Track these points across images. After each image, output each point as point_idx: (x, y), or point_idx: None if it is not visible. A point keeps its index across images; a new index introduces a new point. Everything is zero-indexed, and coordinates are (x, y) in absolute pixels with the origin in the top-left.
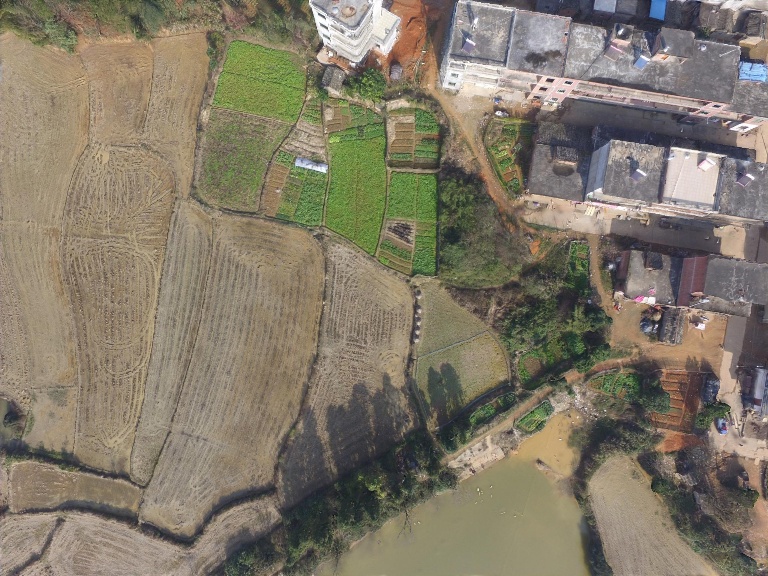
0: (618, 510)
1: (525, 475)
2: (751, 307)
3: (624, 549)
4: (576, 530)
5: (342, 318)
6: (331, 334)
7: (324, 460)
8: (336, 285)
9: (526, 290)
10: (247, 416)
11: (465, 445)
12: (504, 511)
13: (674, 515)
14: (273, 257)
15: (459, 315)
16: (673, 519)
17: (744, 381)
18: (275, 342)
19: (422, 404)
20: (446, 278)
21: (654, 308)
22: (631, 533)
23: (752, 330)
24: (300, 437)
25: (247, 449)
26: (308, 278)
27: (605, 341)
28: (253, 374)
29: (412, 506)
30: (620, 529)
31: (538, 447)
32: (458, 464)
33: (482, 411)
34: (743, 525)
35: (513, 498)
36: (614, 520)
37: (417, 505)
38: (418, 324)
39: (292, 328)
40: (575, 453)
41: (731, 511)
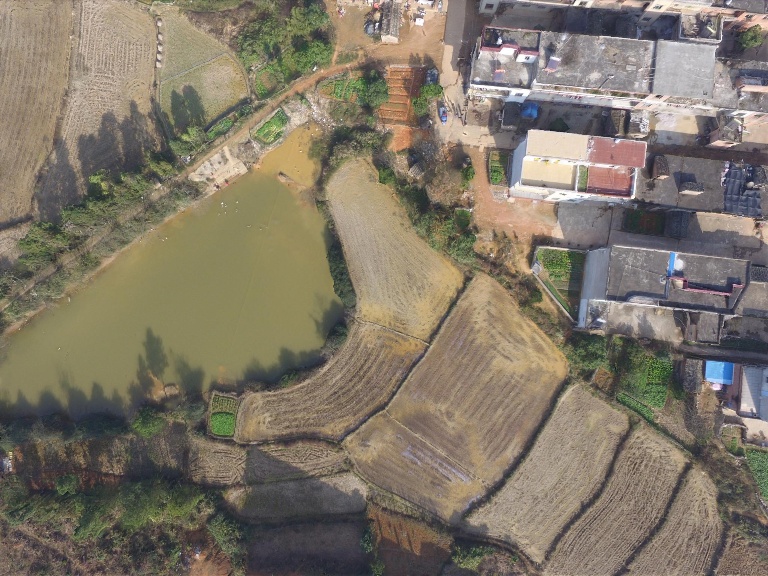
0: (357, 213)
1: (269, 189)
2: (469, 1)
3: (364, 251)
4: (320, 238)
5: (90, 52)
6: (80, 68)
7: (77, 187)
8: (84, 21)
9: (257, 6)
10: (5, 152)
11: (184, 136)
12: (250, 224)
13: (409, 213)
14: (25, 1)
15: (199, 39)
16: (410, 218)
17: (465, 72)
18: (29, 80)
19: (166, 125)
20: (184, 4)
21: (375, 9)
22: (370, 235)
23: (471, 23)
24: (54, 167)
25: (6, 183)
26: (58, 18)
27: (331, 46)
28: (10, 112)
29: (151, 214)
30: (359, 231)
31: (280, 161)
32: (199, 177)
33: (220, 125)
34: (441, 181)
35: (259, 212)
36: (353, 223)
37: (163, 221)
38: (159, 50)
39: (45, 66)
40: (316, 164)
41: (458, 198)
